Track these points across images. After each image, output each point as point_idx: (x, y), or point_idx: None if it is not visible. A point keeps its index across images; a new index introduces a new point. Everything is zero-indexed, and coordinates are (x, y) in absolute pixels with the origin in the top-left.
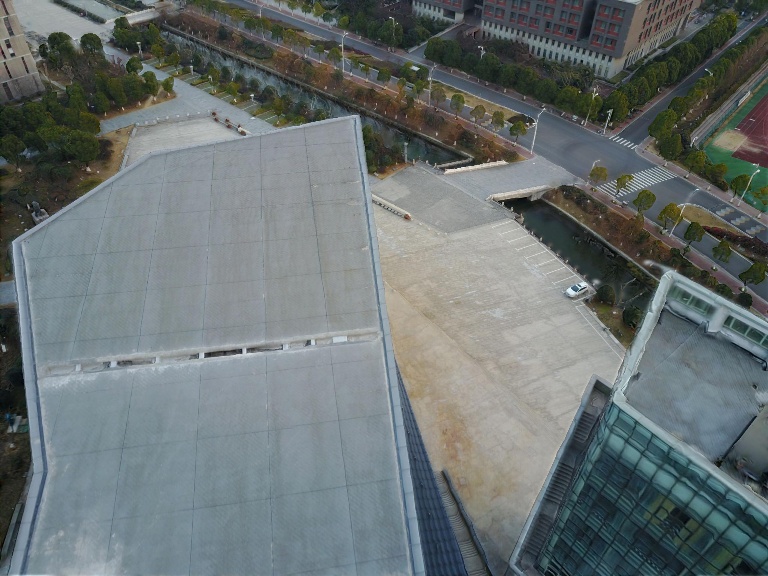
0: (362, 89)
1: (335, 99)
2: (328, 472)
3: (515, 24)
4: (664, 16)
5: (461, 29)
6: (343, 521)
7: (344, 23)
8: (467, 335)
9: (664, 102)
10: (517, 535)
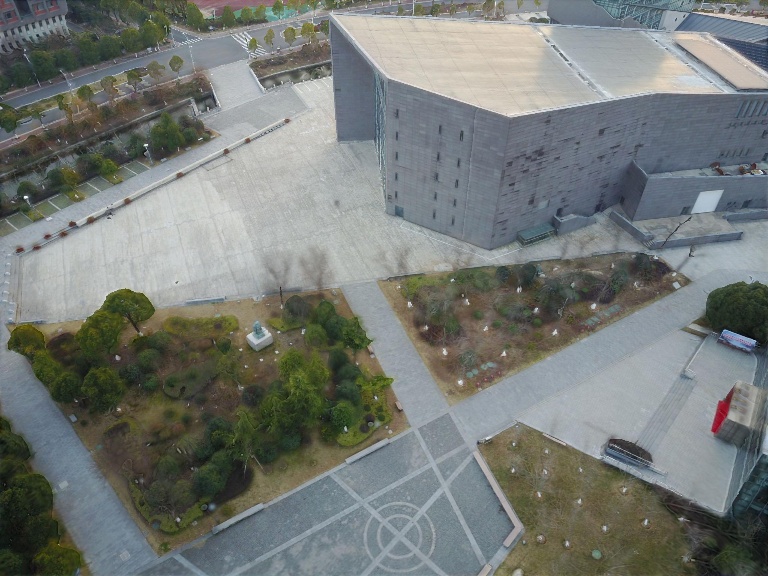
0: (31, 139)
1: (13, 173)
2: None
3: None
4: None
5: None
6: None
7: None
8: None
9: None
10: None
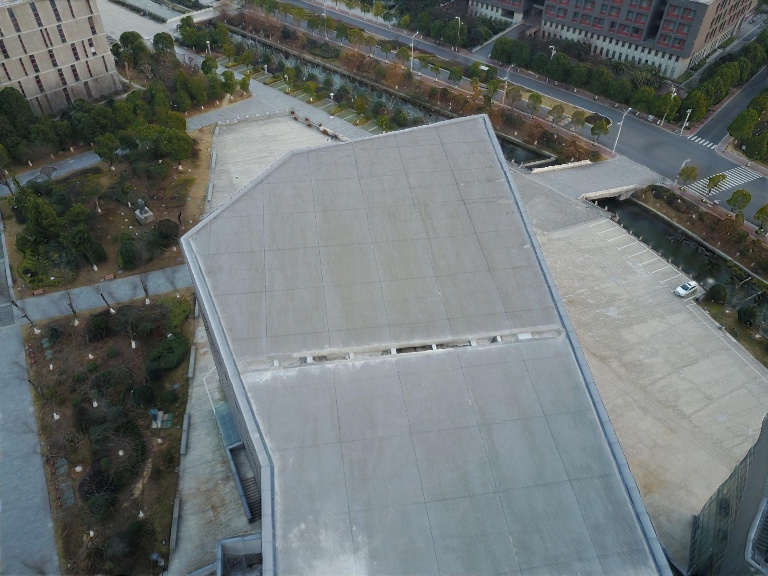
0: (436, 88)
1: (407, 98)
2: (547, 467)
3: (578, 24)
4: (728, 16)
5: (521, 29)
6: (575, 515)
7: (405, 23)
8: (586, 333)
9: (734, 102)
10: (676, 531)
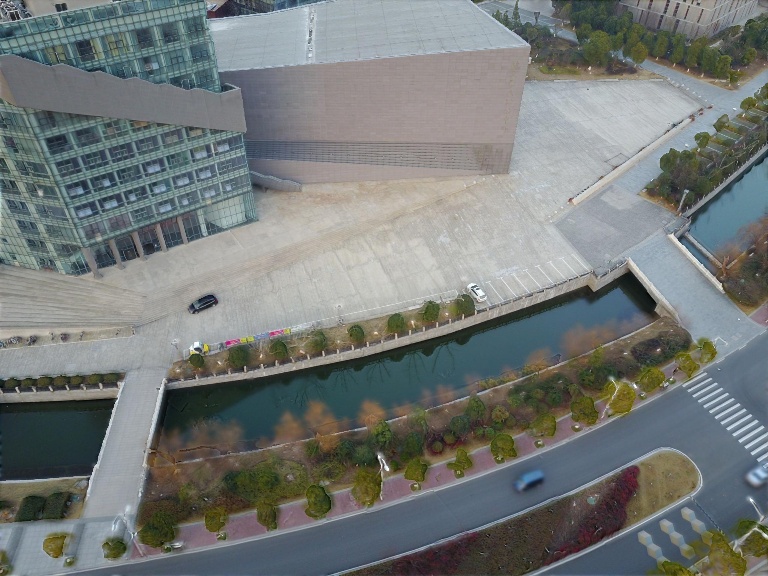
0: None
1: None
2: None
3: None
4: None
5: None
6: None
7: None
8: (419, 219)
9: None
10: None
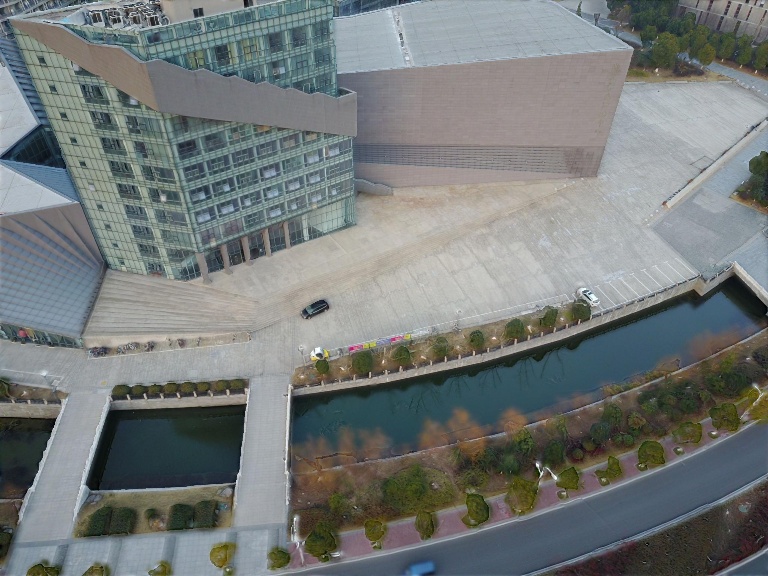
0: None
1: None
2: None
3: None
4: None
5: None
6: None
7: None
8: (515, 222)
9: None
10: None
